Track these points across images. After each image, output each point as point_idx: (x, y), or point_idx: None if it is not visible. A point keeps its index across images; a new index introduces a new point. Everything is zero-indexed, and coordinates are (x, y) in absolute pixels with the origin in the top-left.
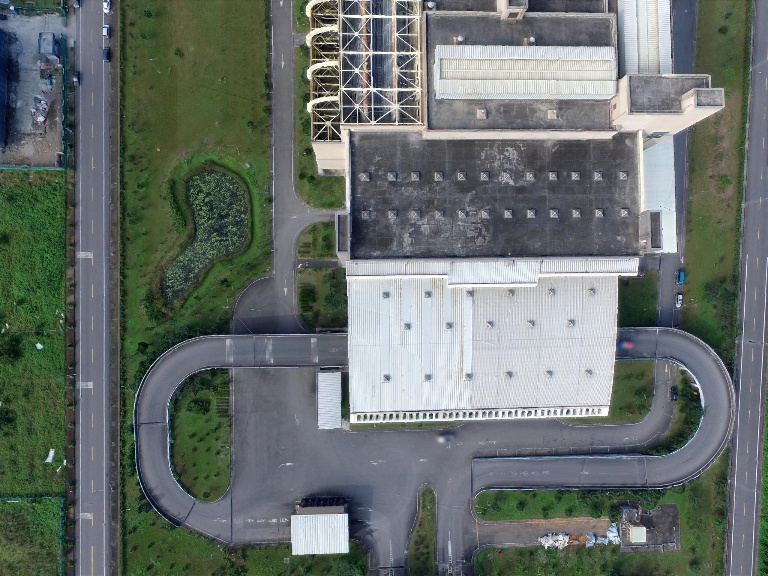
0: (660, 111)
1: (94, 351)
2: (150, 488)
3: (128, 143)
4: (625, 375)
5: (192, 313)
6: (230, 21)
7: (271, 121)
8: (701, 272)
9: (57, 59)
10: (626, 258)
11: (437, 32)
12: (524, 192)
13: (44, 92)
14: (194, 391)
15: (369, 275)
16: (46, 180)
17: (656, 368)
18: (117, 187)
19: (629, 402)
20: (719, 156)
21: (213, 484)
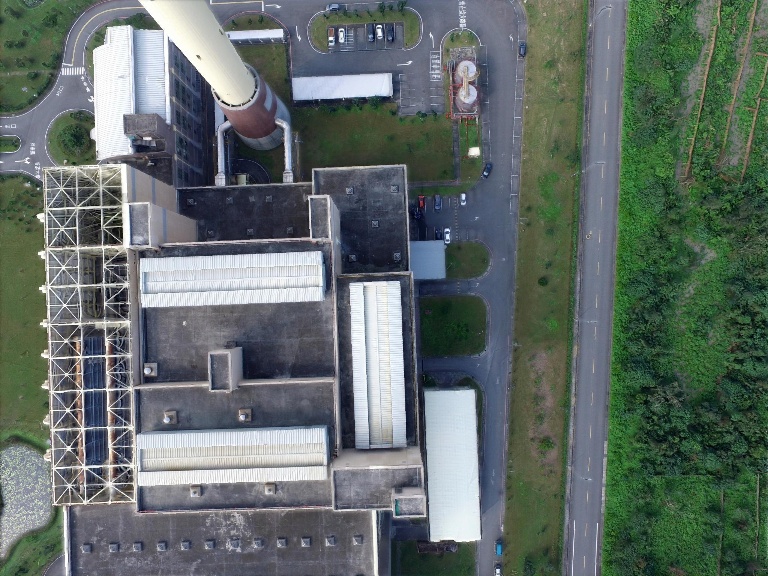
0: (368, 506)
1: None
2: None
3: None
4: None
5: None
6: (31, 294)
7: None
8: (522, 542)
9: None
10: None
11: (150, 405)
12: (252, 560)
13: None
14: None
15: None
16: None
17: None
18: None
19: None
20: (539, 419)
21: None
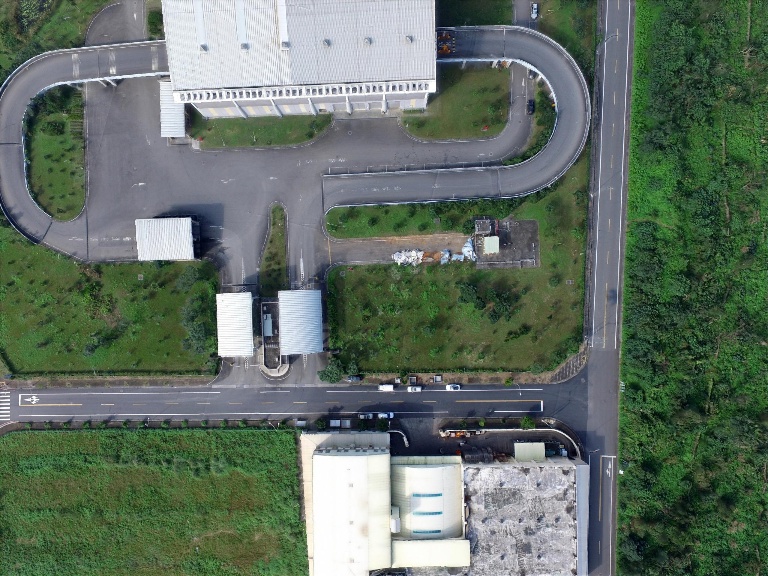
0: None
1: None
2: (9, 207)
3: None
4: (479, 89)
5: (45, 39)
6: None
7: None
8: None
9: None
10: None
11: None
12: None
13: None
14: (46, 110)
15: None
16: None
17: (512, 82)
18: None
19: (483, 117)
20: None
21: (69, 203)
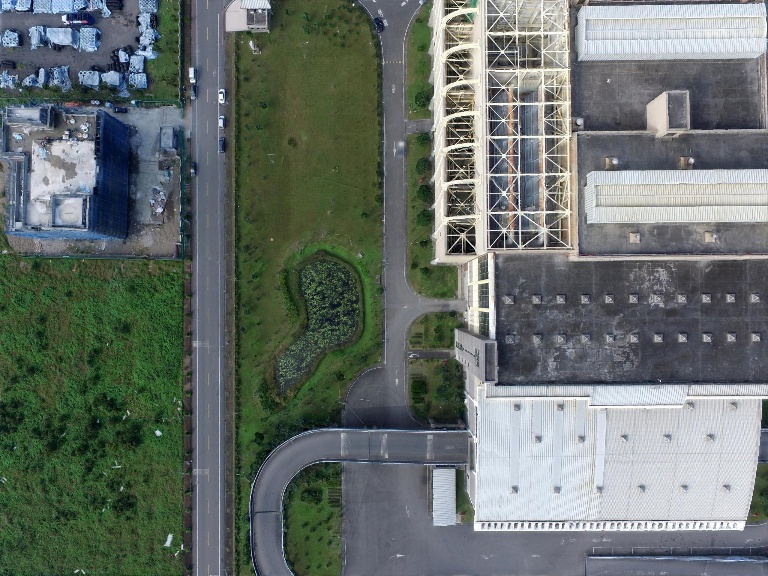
0: None
1: (210, 438)
2: (264, 575)
3: (242, 233)
4: None
5: (305, 403)
6: (342, 109)
7: (383, 210)
8: None
9: (175, 151)
10: None
11: (587, 152)
12: (675, 315)
13: (162, 183)
14: (308, 482)
15: (509, 396)
16: (164, 270)
17: None
18: (232, 276)
19: (753, 502)
20: None
21: (325, 573)
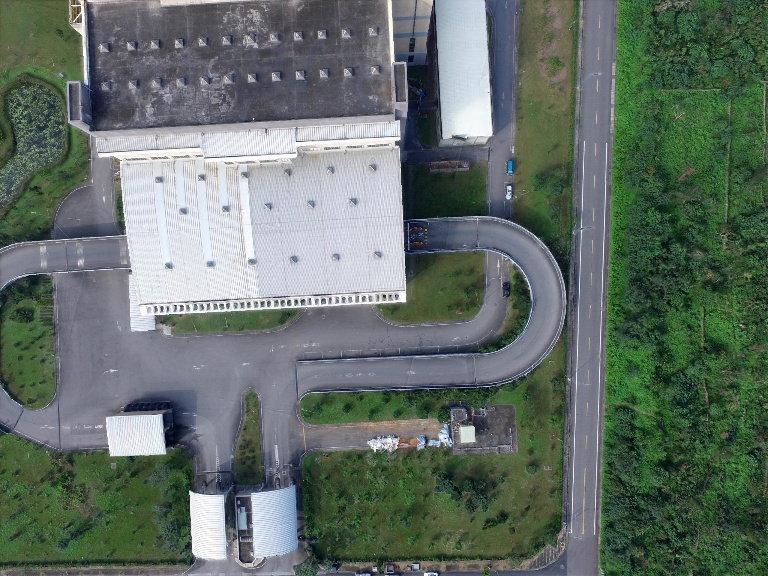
0: None
1: None
2: None
3: None
4: (453, 272)
5: (13, 224)
6: None
7: None
8: (533, 161)
9: None
10: (385, 121)
11: None
12: (269, 55)
13: None
14: (15, 299)
15: (121, 151)
16: None
17: (487, 264)
18: None
19: (458, 300)
20: (547, 37)
21: (40, 391)
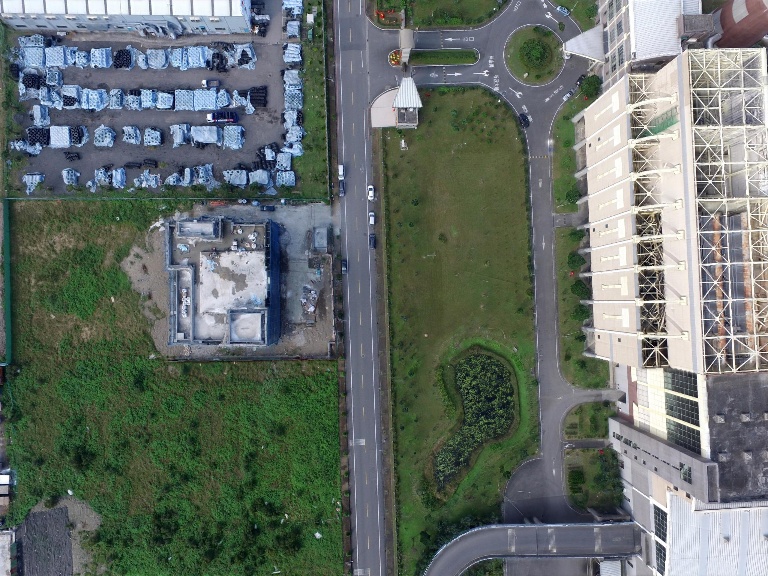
0: None
1: (370, 538)
2: None
3: (396, 329)
4: None
5: (465, 498)
6: (491, 204)
7: (534, 303)
8: None
9: (325, 248)
10: None
11: None
12: None
13: (313, 281)
14: None
15: (716, 509)
16: (318, 369)
17: None
18: (386, 373)
19: None
20: None
21: None
